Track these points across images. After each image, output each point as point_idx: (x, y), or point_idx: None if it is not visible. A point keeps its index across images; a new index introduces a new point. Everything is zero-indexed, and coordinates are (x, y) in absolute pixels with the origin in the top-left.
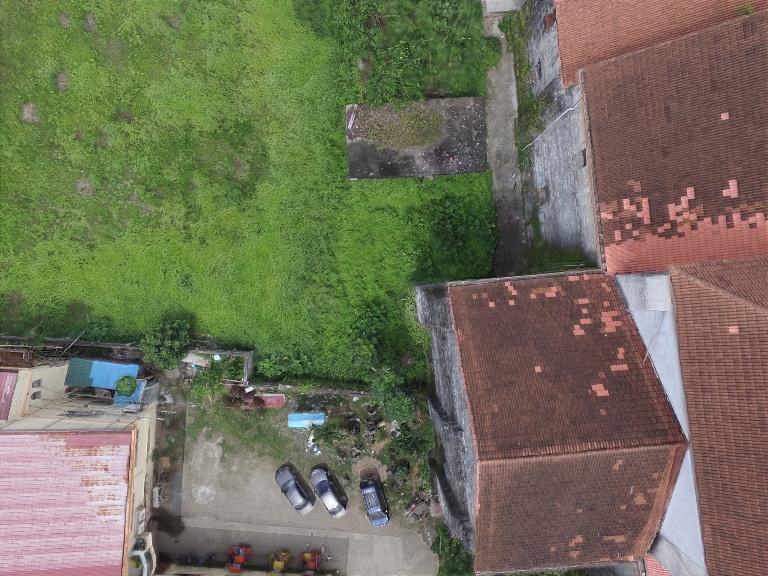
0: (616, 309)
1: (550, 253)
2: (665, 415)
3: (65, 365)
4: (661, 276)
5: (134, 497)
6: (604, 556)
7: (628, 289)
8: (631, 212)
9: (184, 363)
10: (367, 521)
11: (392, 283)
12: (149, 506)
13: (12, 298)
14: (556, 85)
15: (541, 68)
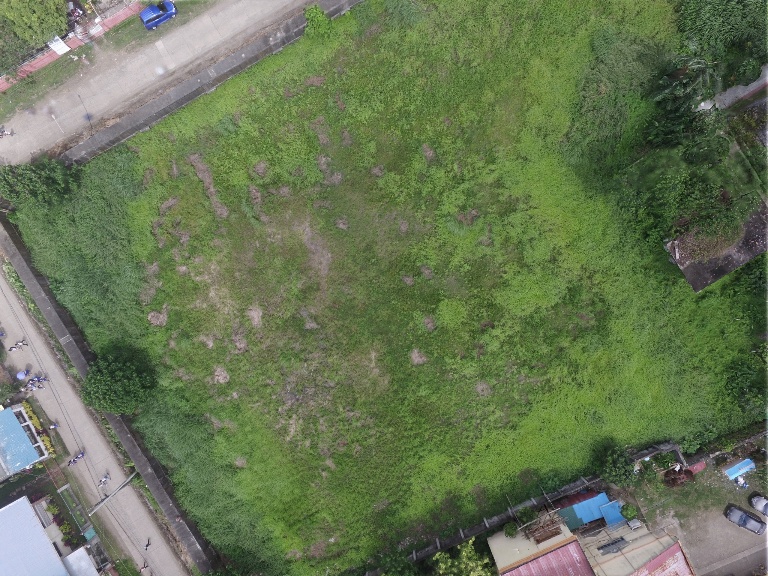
0: None
1: None
2: None
3: None
4: None
5: None
6: None
7: None
8: None
9: None
10: None
11: (737, 343)
12: None
13: (475, 491)
14: None
15: None
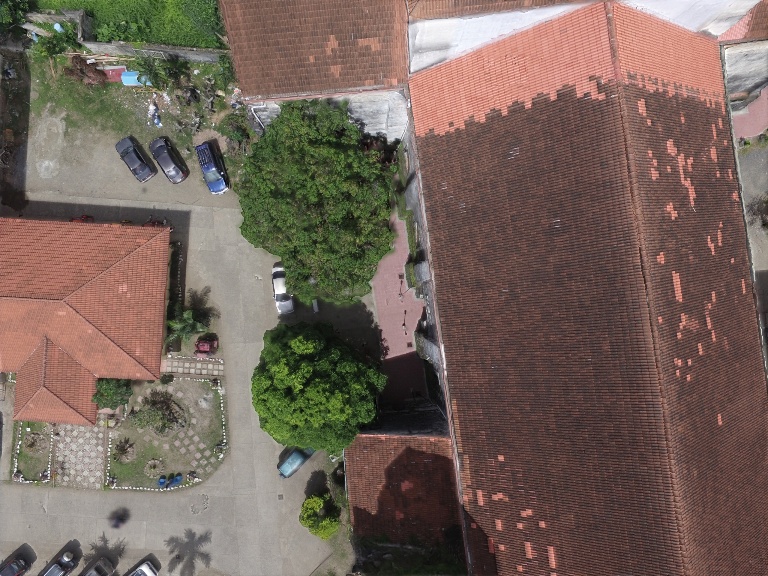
0: None
1: None
2: None
3: None
4: None
5: None
6: (368, 78)
7: None
8: None
9: (27, 37)
10: (208, 194)
11: None
12: None
13: None
14: None
15: None
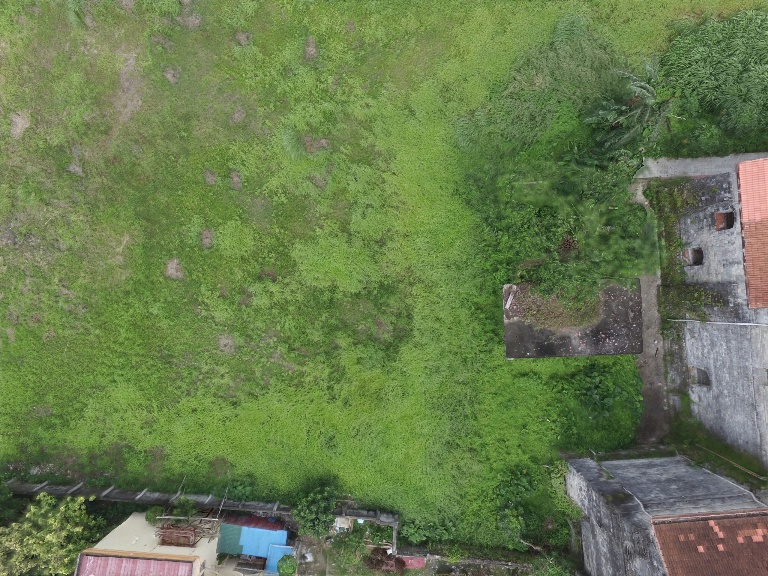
0: None
1: (707, 438)
2: None
3: None
4: None
5: None
6: None
7: None
8: None
9: None
10: None
11: (534, 448)
12: None
13: (154, 453)
14: (732, 291)
15: (703, 257)
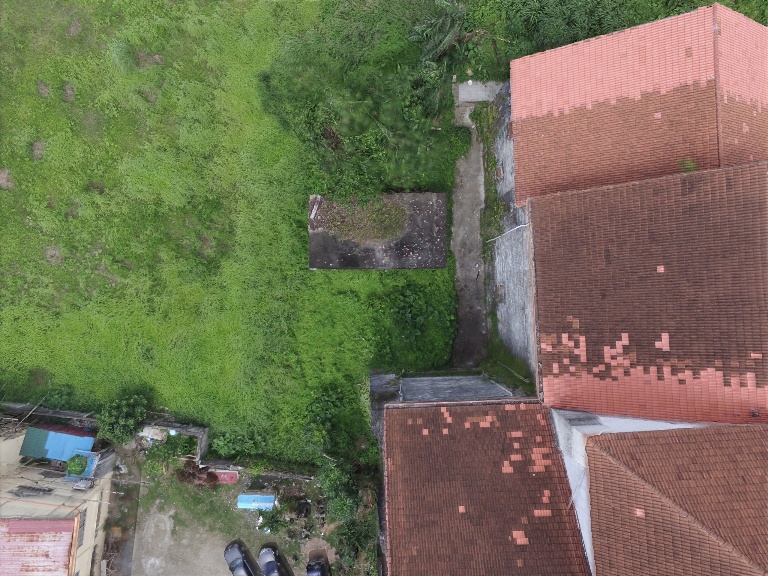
0: (548, 446)
1: (504, 354)
2: (582, 571)
3: (21, 435)
4: (585, 431)
5: (79, 575)
6: None
7: (559, 429)
8: (569, 347)
9: None
10: None
11: (350, 367)
12: (98, 575)
13: None
14: (512, 197)
15: (503, 171)
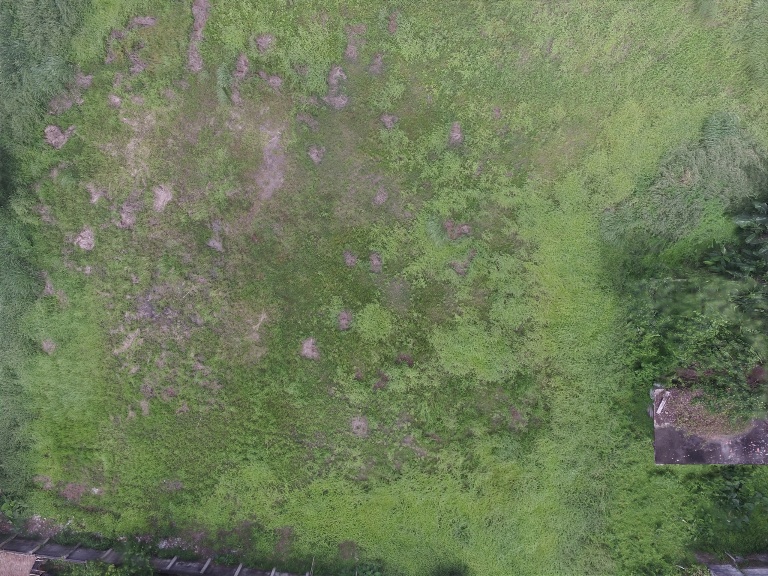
0: None
1: None
2: None
3: None
4: None
5: None
6: None
7: None
8: None
9: None
10: None
11: (668, 547)
12: None
13: (283, 532)
14: None
15: None
